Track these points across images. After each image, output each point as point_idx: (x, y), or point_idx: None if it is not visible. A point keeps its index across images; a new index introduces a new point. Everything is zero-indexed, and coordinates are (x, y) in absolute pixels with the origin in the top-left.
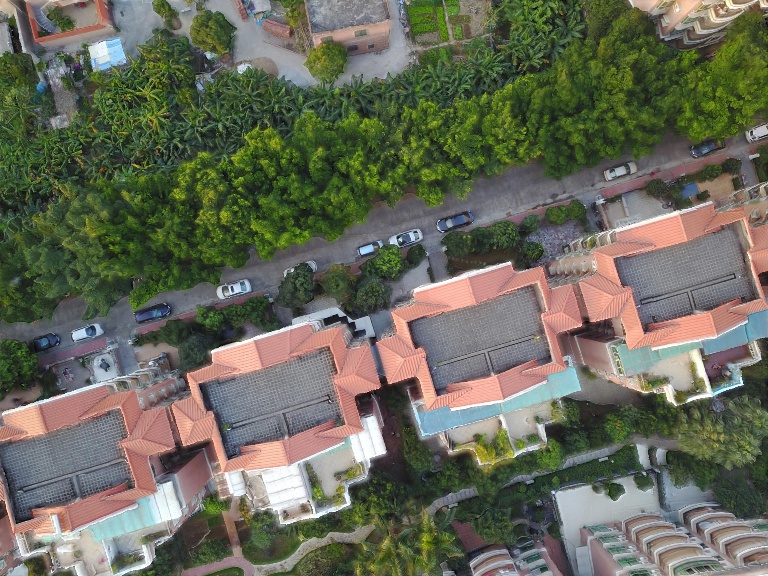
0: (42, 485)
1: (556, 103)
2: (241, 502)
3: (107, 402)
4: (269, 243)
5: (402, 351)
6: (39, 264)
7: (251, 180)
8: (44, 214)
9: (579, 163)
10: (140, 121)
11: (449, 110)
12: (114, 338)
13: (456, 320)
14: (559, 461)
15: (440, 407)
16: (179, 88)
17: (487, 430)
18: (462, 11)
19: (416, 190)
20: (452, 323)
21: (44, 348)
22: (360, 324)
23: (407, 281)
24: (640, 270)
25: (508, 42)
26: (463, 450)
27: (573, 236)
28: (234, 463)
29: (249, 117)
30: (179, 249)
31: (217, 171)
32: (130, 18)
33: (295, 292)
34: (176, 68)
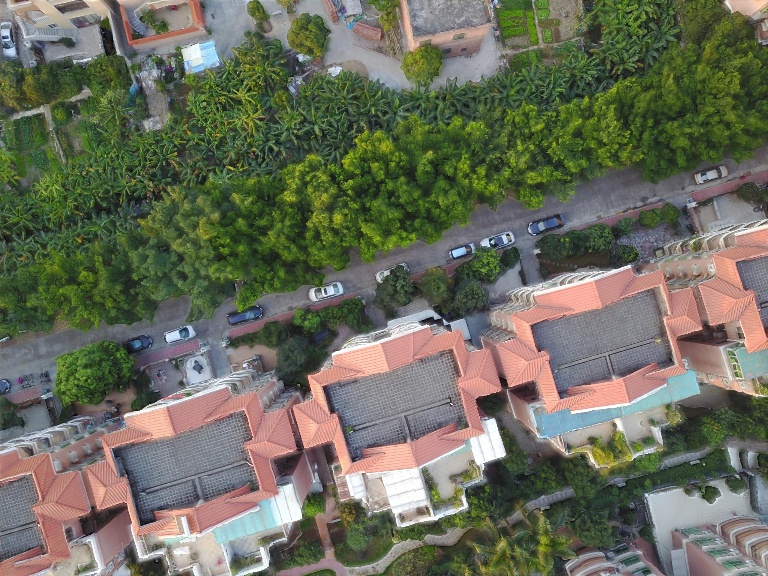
0: (164, 487)
1: (660, 107)
2: (341, 504)
3: (230, 404)
4: (374, 246)
5: (525, 354)
6: (147, 266)
7: (359, 183)
8: (153, 216)
9: (680, 167)
10: (235, 123)
11: (551, 113)
12: (206, 340)
13: (577, 323)
14: (659, 464)
15: (560, 410)
16: (273, 91)
17: (601, 433)
18: (552, 15)
19: (516, 193)
20: (573, 326)
21: (137, 350)
22: (456, 327)
23: (498, 284)
24: (760, 274)
25: (601, 46)
26: (555, 453)
27: (664, 239)
28: (357, 465)
29: (346, 120)
30: (288, 251)
31: (324, 174)
32: (221, 21)
33: (395, 295)
34: (272, 71)
